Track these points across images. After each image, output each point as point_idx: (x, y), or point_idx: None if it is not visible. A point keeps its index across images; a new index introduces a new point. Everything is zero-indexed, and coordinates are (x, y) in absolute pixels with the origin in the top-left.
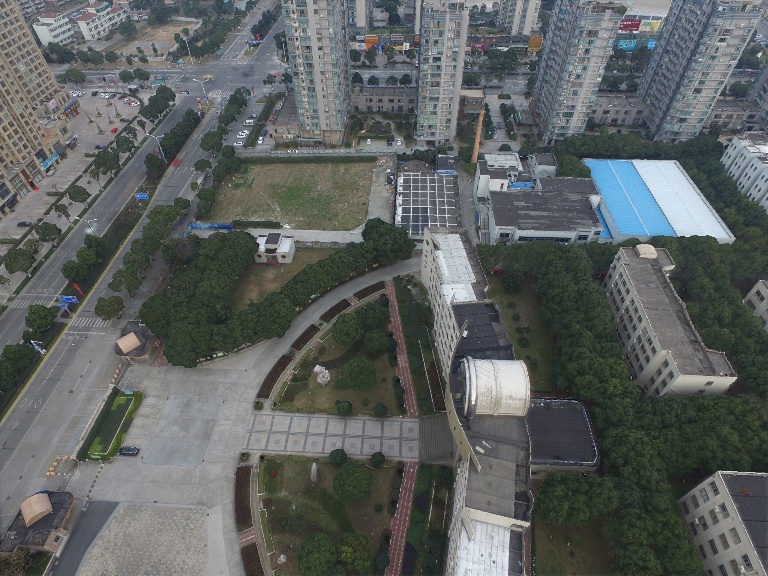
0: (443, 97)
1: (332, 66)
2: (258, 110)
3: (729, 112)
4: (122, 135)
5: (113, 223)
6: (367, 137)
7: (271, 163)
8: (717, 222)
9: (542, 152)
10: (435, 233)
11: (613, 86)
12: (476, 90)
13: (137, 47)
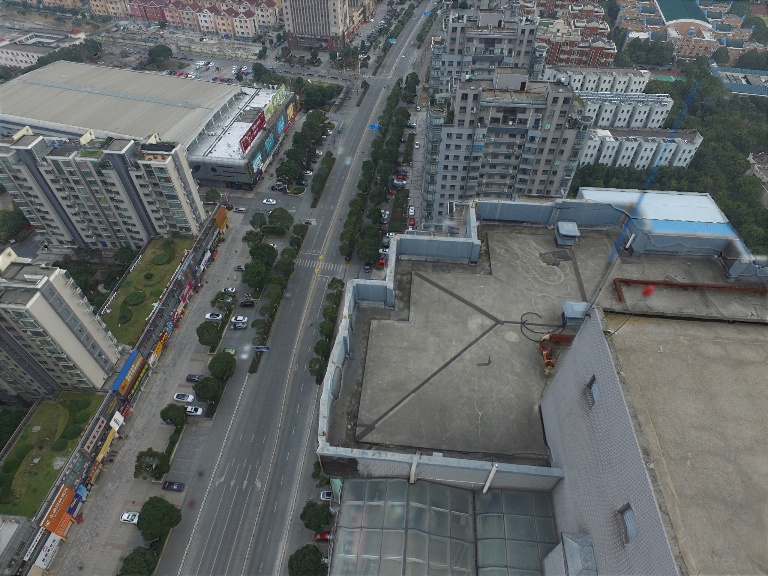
0: None
1: None
2: None
3: None
4: None
5: None
6: None
7: None
8: (683, 195)
9: None
10: None
11: None
12: None
13: None
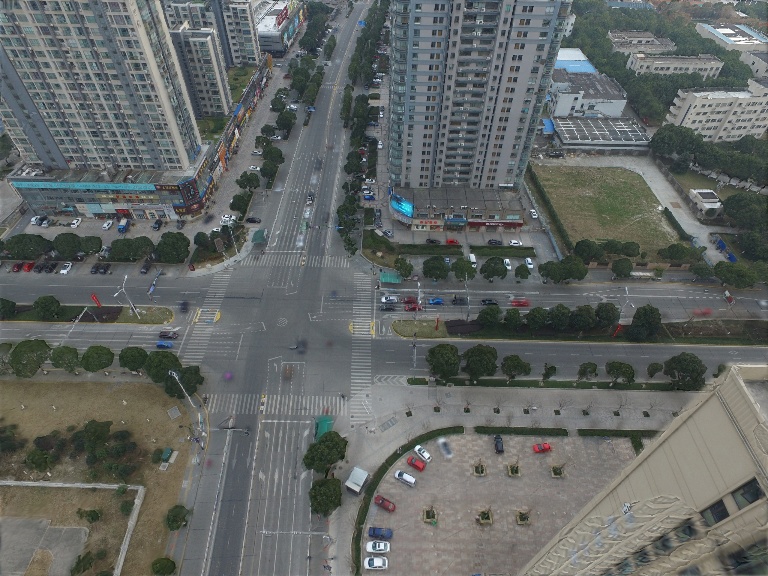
0: None
1: None
2: None
3: None
4: (553, 427)
5: (760, 344)
6: None
7: None
8: (563, 50)
9: None
10: None
11: None
12: None
13: (73, 568)
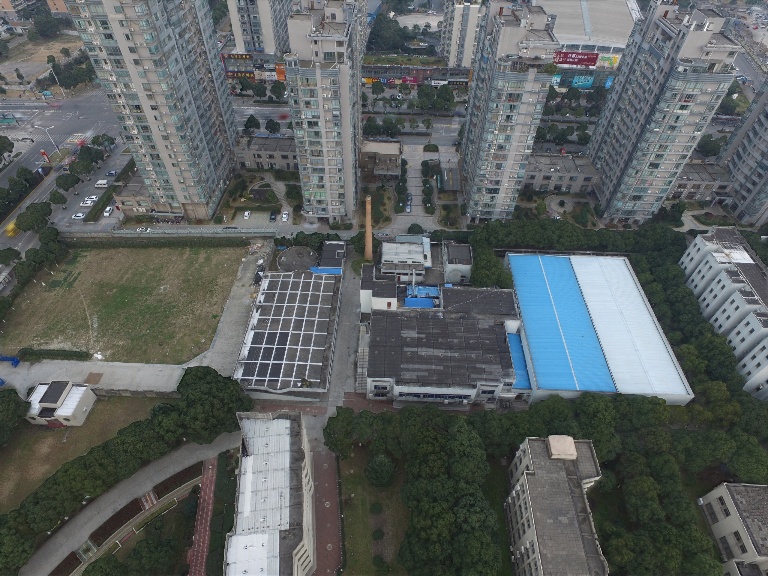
0: (330, 168)
1: (176, 129)
2: (122, 164)
3: (696, 182)
4: None
5: None
6: (245, 208)
7: (111, 247)
8: (671, 364)
9: (460, 237)
10: (254, 419)
11: (560, 139)
12: (392, 144)
13: None
